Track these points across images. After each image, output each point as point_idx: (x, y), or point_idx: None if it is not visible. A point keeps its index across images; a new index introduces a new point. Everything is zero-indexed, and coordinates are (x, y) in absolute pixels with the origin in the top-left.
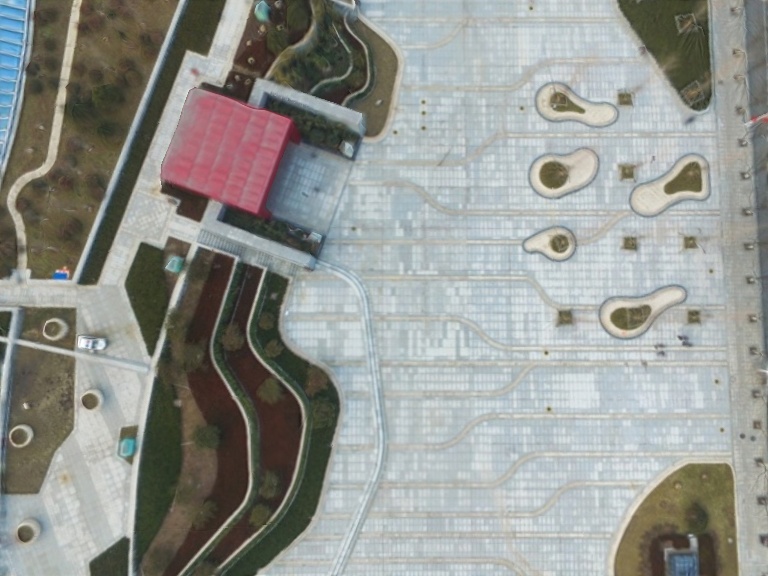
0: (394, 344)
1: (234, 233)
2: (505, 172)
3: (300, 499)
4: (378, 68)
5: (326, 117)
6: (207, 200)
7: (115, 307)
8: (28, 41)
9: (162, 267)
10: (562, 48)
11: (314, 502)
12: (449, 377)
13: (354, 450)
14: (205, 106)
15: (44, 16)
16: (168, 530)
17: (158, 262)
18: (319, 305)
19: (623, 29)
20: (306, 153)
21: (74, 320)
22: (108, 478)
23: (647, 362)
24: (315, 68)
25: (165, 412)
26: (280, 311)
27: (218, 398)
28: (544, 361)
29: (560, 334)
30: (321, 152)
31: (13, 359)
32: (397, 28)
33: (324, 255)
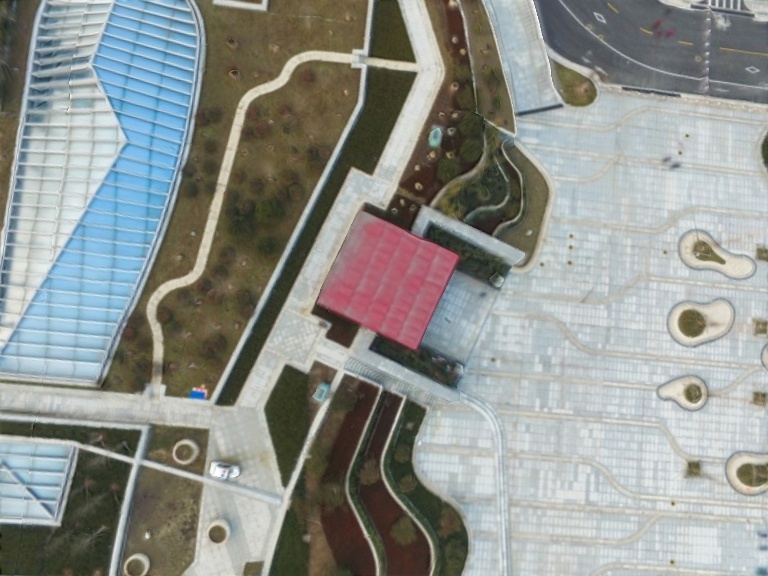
0: (525, 483)
1: (385, 365)
2: (645, 315)
3: None
4: (530, 197)
5: (486, 251)
6: (360, 327)
7: (251, 431)
8: (187, 140)
9: (306, 393)
10: (707, 196)
11: None
12: (577, 522)
13: None
14: (372, 232)
15: (208, 116)
16: None
17: (302, 387)
18: (453, 437)
19: (765, 184)
20: (453, 278)
21: (206, 442)
22: None
23: (767, 520)
24: (475, 196)
25: (293, 548)
26: (414, 441)
27: (350, 536)
28: (670, 512)
29: (687, 485)
30: (469, 279)
31: (137, 482)
32: (550, 157)
33: (462, 385)
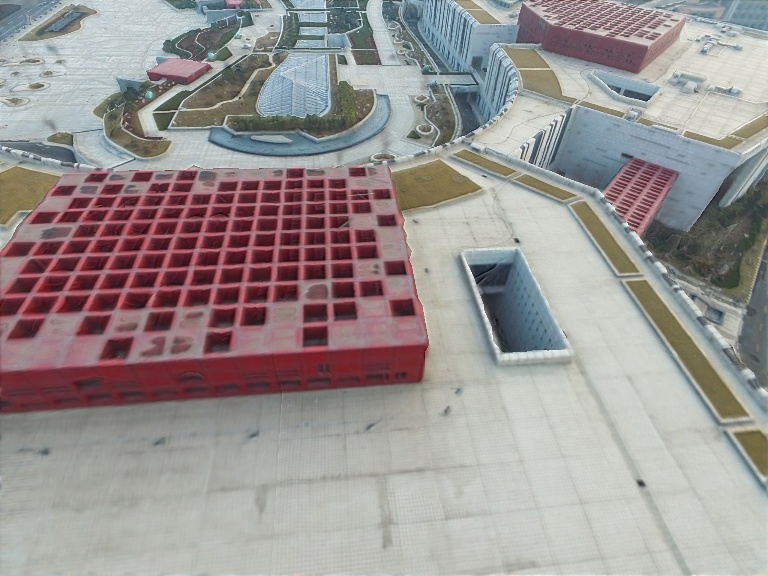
0: None
1: None
2: None
3: None
4: None
5: None
6: None
7: None
8: None
9: None
10: (0, 115)
11: None
12: None
13: None
14: None
15: None
16: None
17: None
18: None
19: None
20: None
21: None
22: None
23: (32, 55)
24: None
25: None
26: None
27: None
28: None
29: None
30: None
31: None
32: None
33: None
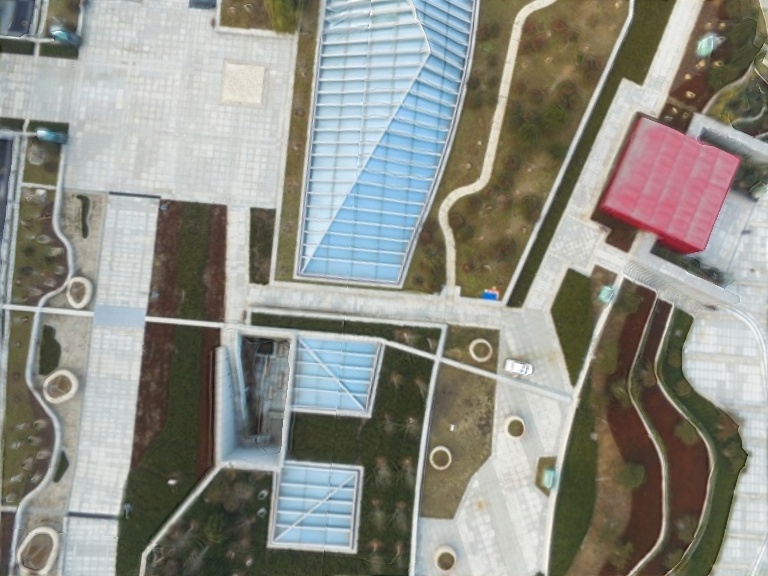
0: None
1: (667, 267)
2: None
3: (704, 546)
4: None
5: (756, 157)
6: (639, 231)
7: (539, 332)
8: (470, 54)
9: (590, 295)
10: None
11: (716, 550)
12: None
13: (752, 498)
14: (654, 137)
15: (489, 31)
16: (578, 568)
17: (586, 290)
18: (718, 346)
19: None
20: None
21: (497, 342)
22: (524, 509)
23: None
24: (737, 106)
25: (583, 445)
26: (682, 349)
27: (636, 435)
28: None
29: None
30: (728, 190)
31: (438, 377)
32: None
33: None
